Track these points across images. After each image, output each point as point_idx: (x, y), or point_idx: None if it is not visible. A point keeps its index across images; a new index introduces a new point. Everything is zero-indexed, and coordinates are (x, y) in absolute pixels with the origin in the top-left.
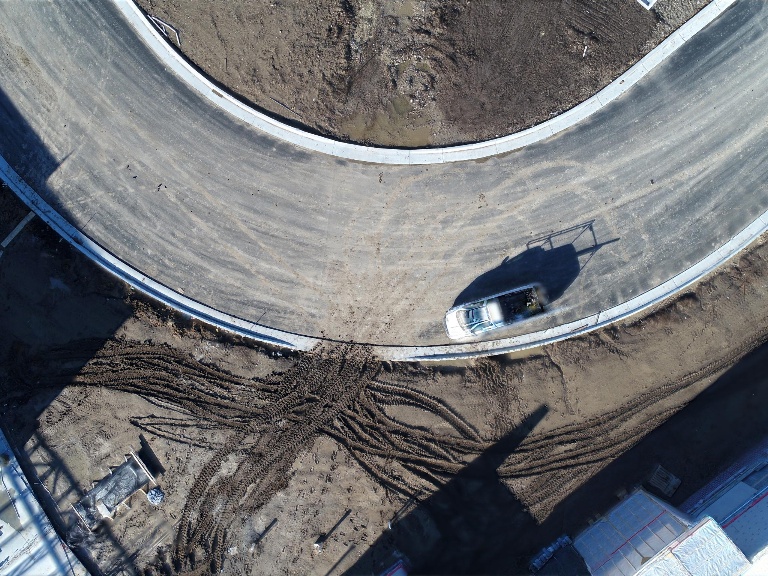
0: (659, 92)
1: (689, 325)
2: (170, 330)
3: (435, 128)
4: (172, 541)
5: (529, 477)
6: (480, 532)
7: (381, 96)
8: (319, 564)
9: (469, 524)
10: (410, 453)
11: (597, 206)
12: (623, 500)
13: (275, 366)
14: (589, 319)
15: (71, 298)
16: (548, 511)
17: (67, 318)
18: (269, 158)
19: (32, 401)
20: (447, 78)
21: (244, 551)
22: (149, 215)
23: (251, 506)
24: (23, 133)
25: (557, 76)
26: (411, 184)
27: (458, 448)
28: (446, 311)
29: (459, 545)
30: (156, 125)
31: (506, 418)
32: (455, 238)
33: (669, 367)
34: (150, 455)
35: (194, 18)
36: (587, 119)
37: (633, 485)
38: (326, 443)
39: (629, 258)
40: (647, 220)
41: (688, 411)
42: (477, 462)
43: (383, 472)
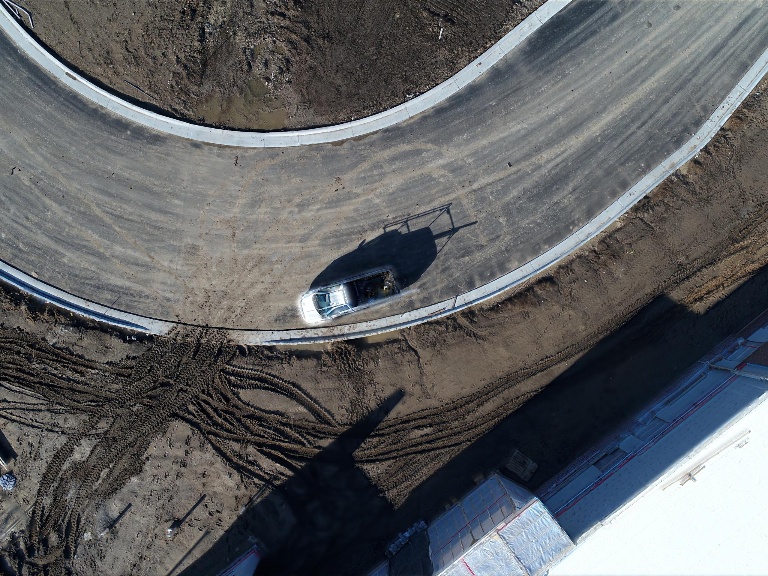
0: (516, 74)
1: (546, 308)
2: (23, 314)
3: (291, 111)
4: (25, 526)
5: (385, 462)
6: (336, 517)
7: (236, 79)
8: (174, 550)
9: (325, 509)
10: (265, 438)
11: (454, 189)
12: (479, 485)
13: (129, 350)
14: (446, 303)
15: None
16: (405, 496)
17: None
18: (124, 141)
19: None
20: (302, 60)
21: (98, 537)
22: (3, 198)
23: (105, 491)
24: None
25: (413, 58)
26: (267, 167)
27: (313, 432)
28: (302, 295)
29: (315, 530)
30: (10, 108)
31: (362, 402)
32: (311, 221)
33: (526, 351)
34: (2, 440)
35: (47, 0)
36: (444, 102)
37: (490, 470)
38: (180, 428)
39: (487, 241)
40: (505, 203)
41: (545, 395)
42: (333, 447)
43: (238, 457)
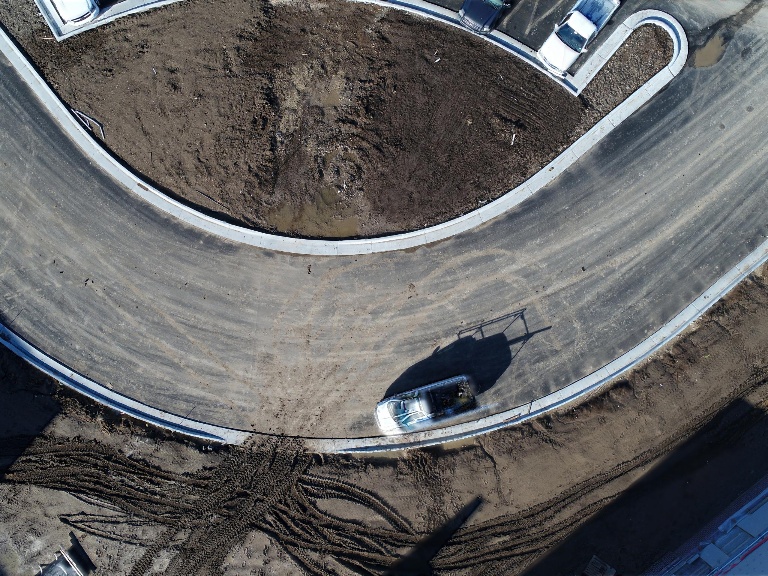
0: (589, 178)
1: (622, 413)
2: (99, 426)
3: (363, 218)
4: None
5: (463, 569)
6: None
7: (308, 187)
8: None
9: None
10: (342, 546)
11: (528, 294)
12: None
13: (205, 461)
14: (521, 408)
15: None
16: None
17: None
18: (196, 251)
19: None
20: (374, 168)
21: None
22: (76, 310)
23: None
24: None
25: (486, 164)
26: (340, 275)
27: (391, 541)
28: (377, 402)
29: None
30: (82, 219)
31: (439, 510)
32: (385, 329)
33: (602, 456)
34: (80, 553)
35: (118, 112)
36: (517, 207)
37: (568, 575)
38: (258, 537)
39: (561, 346)
40: (579, 308)
41: (622, 500)
42: (410, 554)
43: (315, 566)
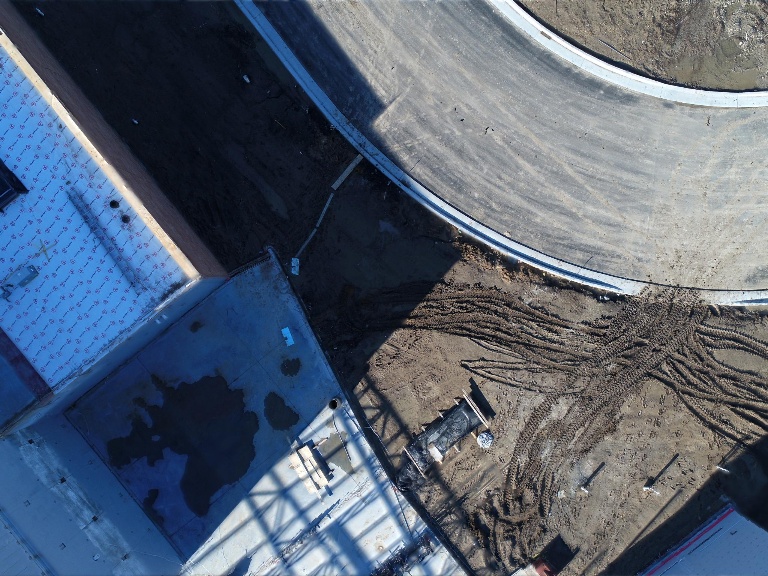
0: None
1: None
2: (498, 274)
3: (763, 71)
4: (500, 485)
5: None
6: None
7: (709, 38)
8: (646, 508)
9: None
10: (739, 397)
11: None
12: None
13: (604, 310)
14: None
15: (400, 241)
16: None
17: (397, 261)
18: (597, 101)
19: (362, 344)
20: None
21: (571, 495)
22: (476, 158)
23: (578, 450)
24: (350, 75)
25: None
26: (738, 127)
27: None
28: None
29: None
30: (483, 67)
31: None
32: None
33: None
34: (480, 398)
35: None
36: None
37: None
38: (654, 387)
39: None
40: None
41: None
42: None
43: (712, 416)
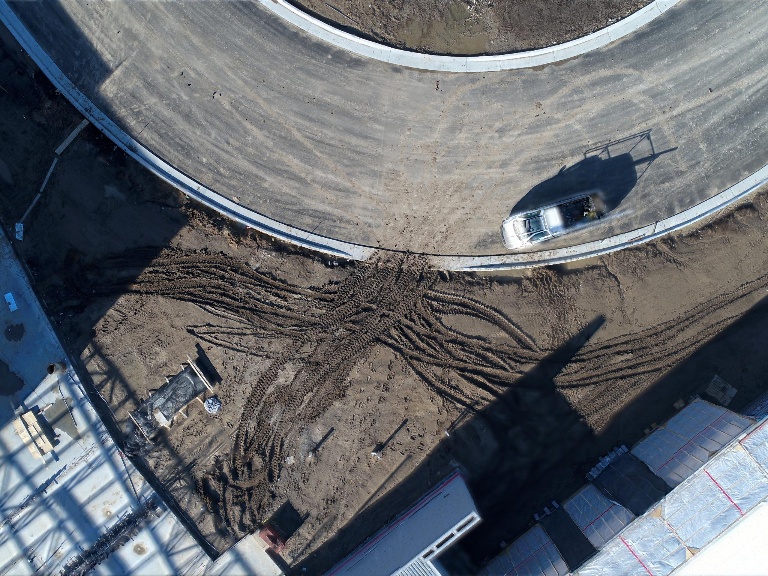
0: None
1: (747, 234)
2: (226, 239)
3: (492, 35)
4: (229, 450)
5: (586, 386)
6: (536, 441)
7: (438, 2)
8: (376, 473)
9: (525, 433)
10: (467, 362)
11: (655, 115)
12: (679, 409)
13: (331, 275)
14: (646, 229)
15: (126, 206)
16: (604, 420)
17: (122, 227)
18: (325, 65)
19: (88, 310)
20: None
21: (301, 460)
22: (204, 123)
23: (308, 415)
24: (76, 40)
25: None
26: (468, 92)
27: (515, 357)
28: (503, 221)
29: (515, 454)
30: (210, 32)
31: (563, 327)
32: (512, 147)
33: (726, 276)
34: (207, 364)
35: None
36: (646, 26)
37: (689, 394)
38: (383, 352)
39: (687, 167)
40: (705, 129)
41: (745, 320)
42: (534, 371)
43: (440, 381)
